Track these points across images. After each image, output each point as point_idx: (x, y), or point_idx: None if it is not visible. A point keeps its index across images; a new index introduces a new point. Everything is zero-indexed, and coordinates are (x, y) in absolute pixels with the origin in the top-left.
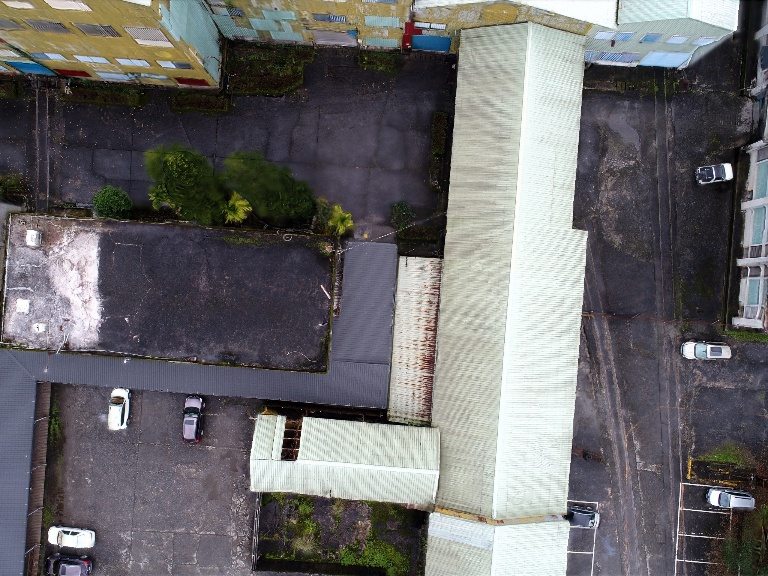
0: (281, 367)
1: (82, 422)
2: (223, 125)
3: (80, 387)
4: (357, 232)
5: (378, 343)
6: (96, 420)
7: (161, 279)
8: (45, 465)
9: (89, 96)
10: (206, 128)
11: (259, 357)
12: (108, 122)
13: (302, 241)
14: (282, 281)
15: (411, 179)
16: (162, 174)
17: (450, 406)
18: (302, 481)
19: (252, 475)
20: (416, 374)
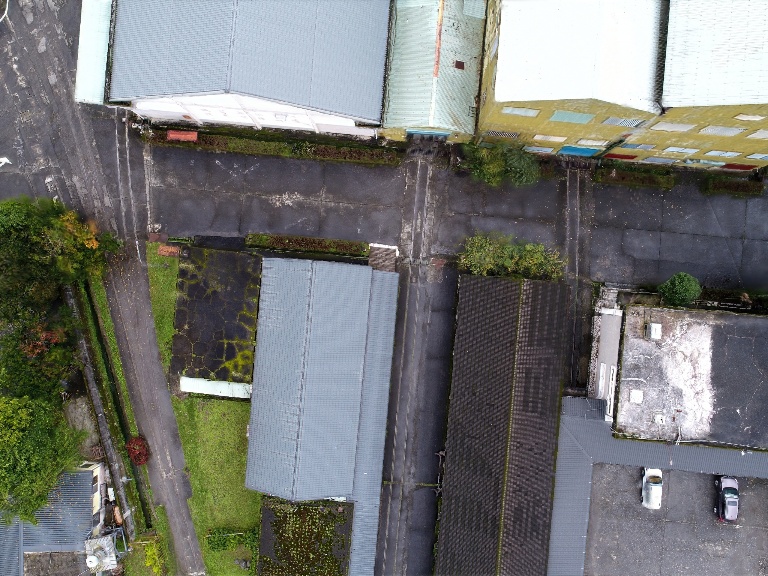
0: None
1: (608, 499)
2: (752, 207)
3: (607, 464)
4: None
5: None
6: (622, 497)
7: None
8: None
9: (627, 178)
10: (735, 210)
11: None
12: (637, 203)
13: None
14: None
15: None
16: (691, 255)
17: None
18: None
19: None
20: None
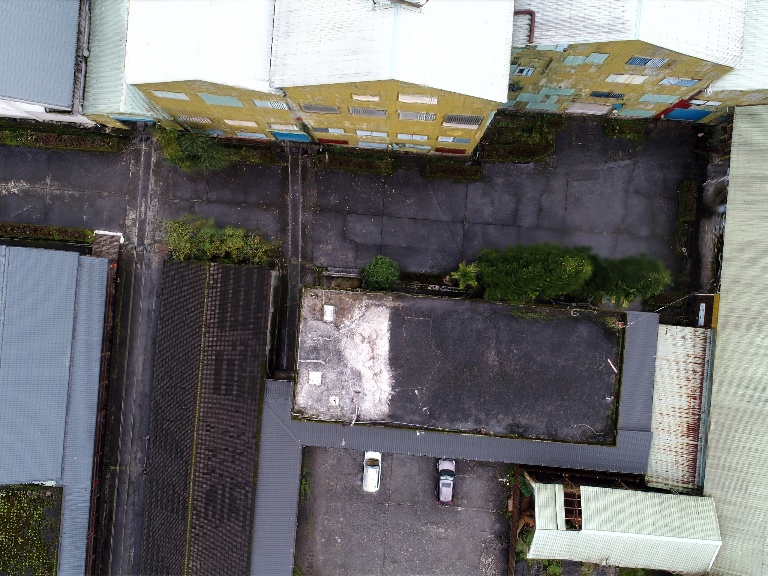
0: (568, 439)
1: (332, 482)
2: (473, 191)
3: (331, 448)
4: (605, 297)
5: (640, 410)
6: (346, 480)
7: (451, 352)
8: (296, 524)
9: (345, 163)
10: (456, 194)
11: (546, 429)
12: (359, 188)
13: (589, 316)
14: (570, 355)
15: (658, 245)
16: (412, 239)
17: (725, 476)
18: (581, 549)
19: (534, 544)
20: (678, 441)
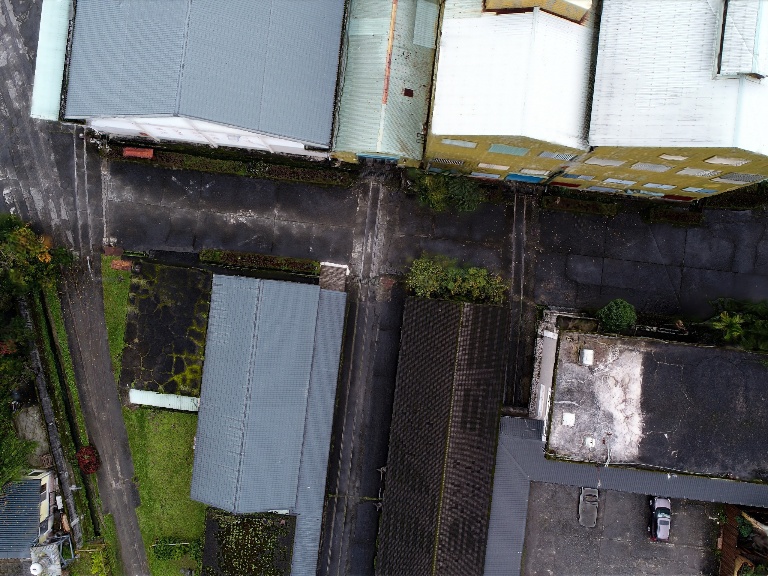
0: None
1: (546, 516)
2: (692, 236)
3: None
4: None
5: None
6: (560, 515)
7: (700, 398)
8: None
9: (572, 205)
10: (675, 239)
11: None
12: (582, 229)
13: None
14: None
15: None
16: (632, 281)
17: None
18: None
19: None
20: None
